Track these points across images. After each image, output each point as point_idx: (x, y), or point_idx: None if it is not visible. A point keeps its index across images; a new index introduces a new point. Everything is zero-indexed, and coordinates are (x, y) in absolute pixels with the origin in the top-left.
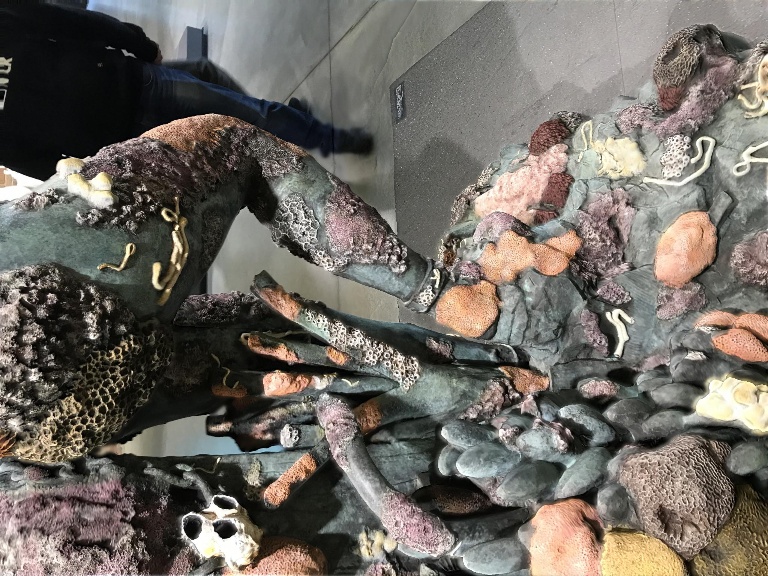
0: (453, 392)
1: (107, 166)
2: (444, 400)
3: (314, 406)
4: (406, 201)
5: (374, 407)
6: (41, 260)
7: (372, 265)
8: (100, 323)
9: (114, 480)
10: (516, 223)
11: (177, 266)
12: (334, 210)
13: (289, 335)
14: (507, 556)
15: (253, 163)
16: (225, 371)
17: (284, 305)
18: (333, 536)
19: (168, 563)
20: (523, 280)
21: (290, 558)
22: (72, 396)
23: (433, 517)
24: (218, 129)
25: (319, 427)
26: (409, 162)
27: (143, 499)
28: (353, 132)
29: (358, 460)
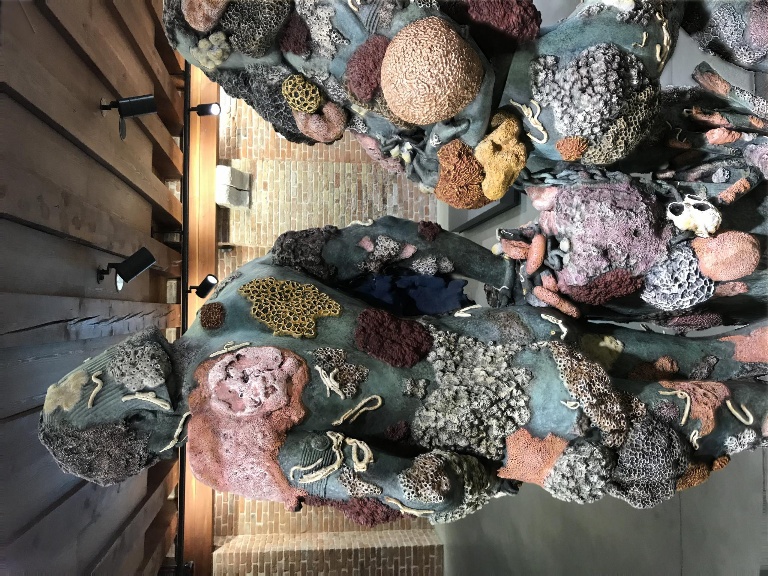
0: None
1: None
2: None
3: (733, 163)
4: None
5: None
6: (605, 40)
7: None
8: (638, 75)
9: (626, 182)
10: None
11: (668, 47)
12: (759, 13)
13: None
14: None
15: None
16: (678, 130)
17: (720, 84)
18: (760, 236)
19: (660, 231)
20: None
21: (738, 235)
22: (622, 118)
23: None
24: None
25: (744, 170)
26: None
27: (643, 194)
28: None
29: None
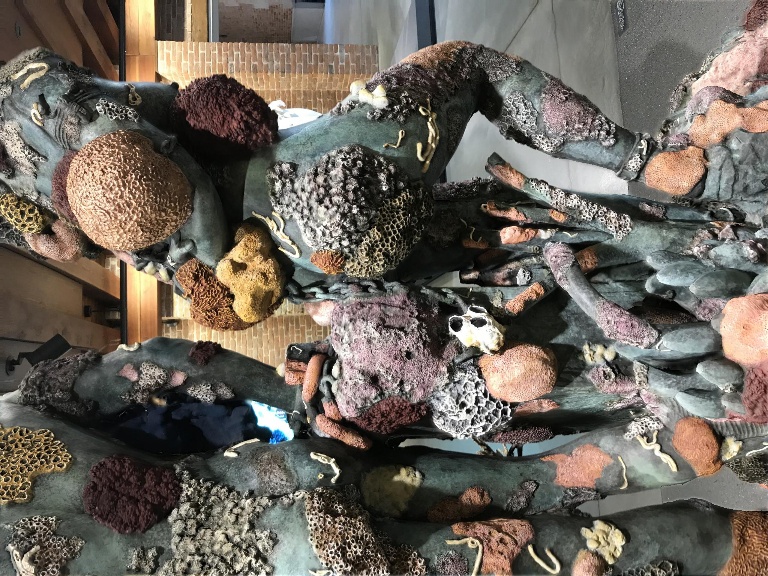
0: (663, 240)
1: (381, 83)
2: (655, 247)
3: (543, 259)
4: (633, 110)
5: (591, 252)
6: (350, 143)
7: (584, 142)
8: (388, 180)
9: (402, 294)
10: (725, 93)
11: (432, 145)
12: (549, 99)
13: (519, 204)
14: (700, 337)
15: (481, 73)
16: (471, 229)
17: (512, 177)
18: (561, 346)
19: (442, 349)
20: (730, 141)
21: (527, 350)
22: (375, 228)
23: (639, 318)
24: (453, 50)
25: (547, 270)
26: (634, 72)
27: (422, 307)
28: (579, 57)
29: (576, 279)
